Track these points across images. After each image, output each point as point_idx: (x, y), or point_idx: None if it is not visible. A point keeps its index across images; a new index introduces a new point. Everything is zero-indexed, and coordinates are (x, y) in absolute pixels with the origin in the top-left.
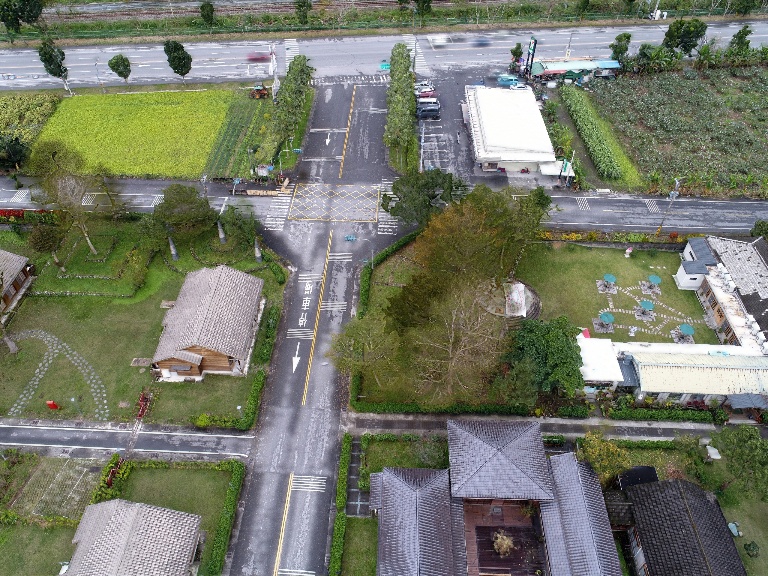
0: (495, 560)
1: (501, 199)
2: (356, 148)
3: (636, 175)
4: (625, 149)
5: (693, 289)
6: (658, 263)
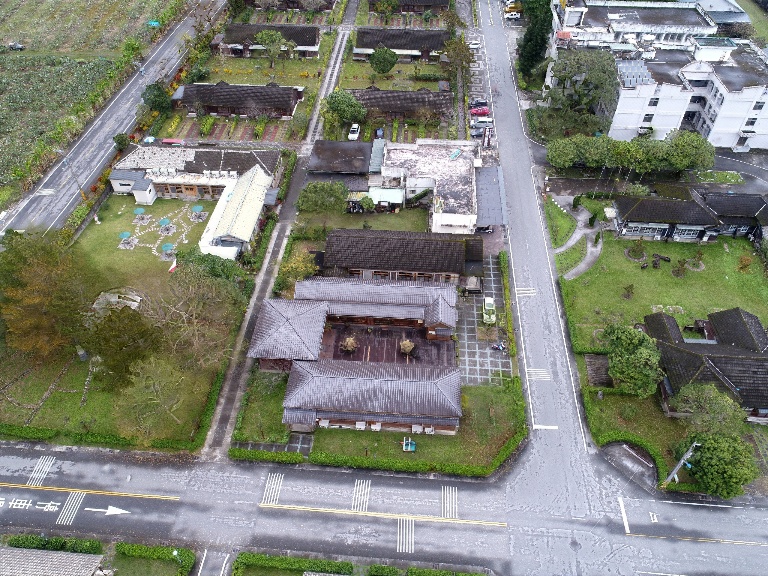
0: (358, 354)
1: (30, 244)
2: None
3: None
4: None
5: (155, 198)
6: (117, 208)
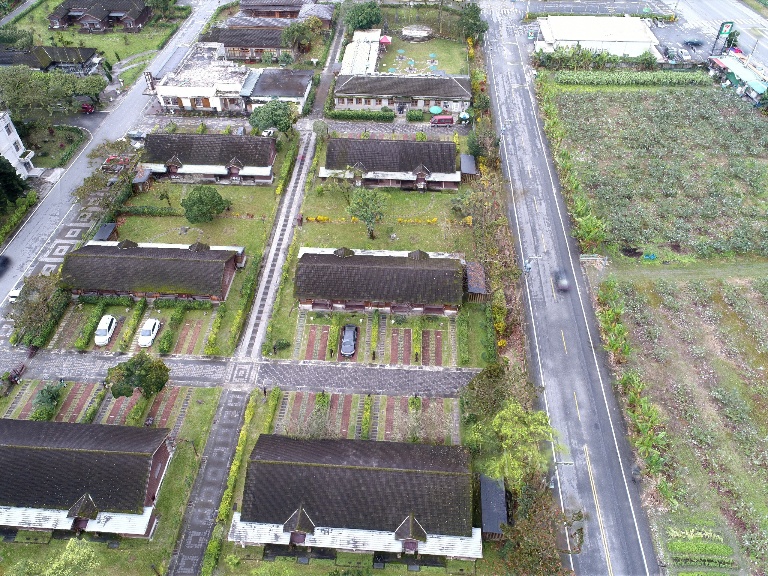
0: None
1: None
2: (555, 4)
3: None
4: None
5: None
6: None
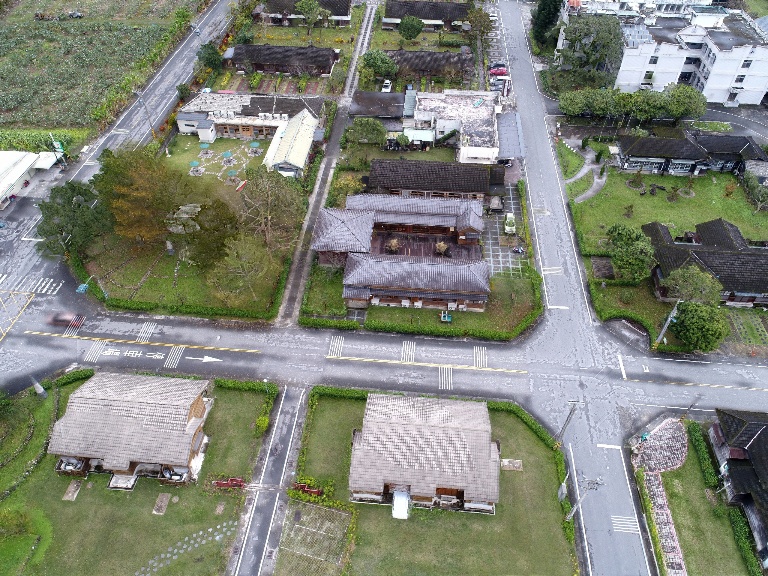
0: (401, 254)
1: (132, 154)
2: None
3: (74, 131)
4: (32, 129)
5: (215, 137)
6: (183, 145)
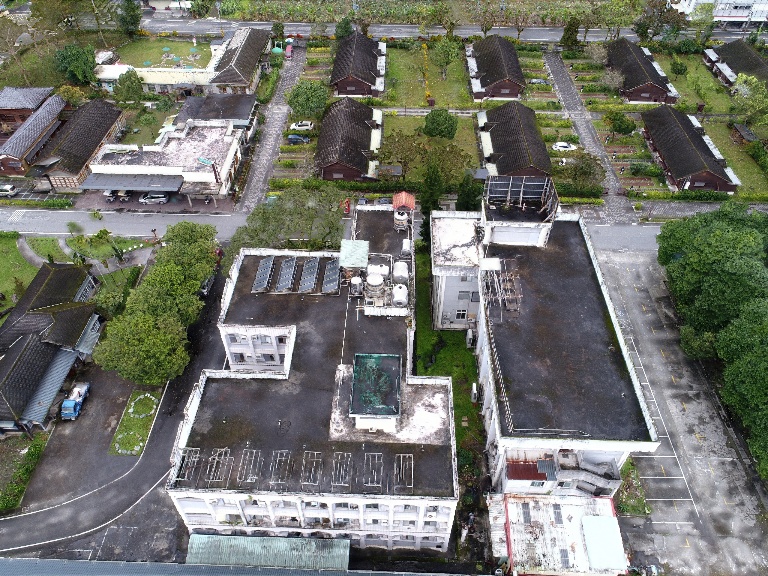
0: (3, 137)
1: None
2: None
3: None
4: (253, 2)
5: None
6: None
